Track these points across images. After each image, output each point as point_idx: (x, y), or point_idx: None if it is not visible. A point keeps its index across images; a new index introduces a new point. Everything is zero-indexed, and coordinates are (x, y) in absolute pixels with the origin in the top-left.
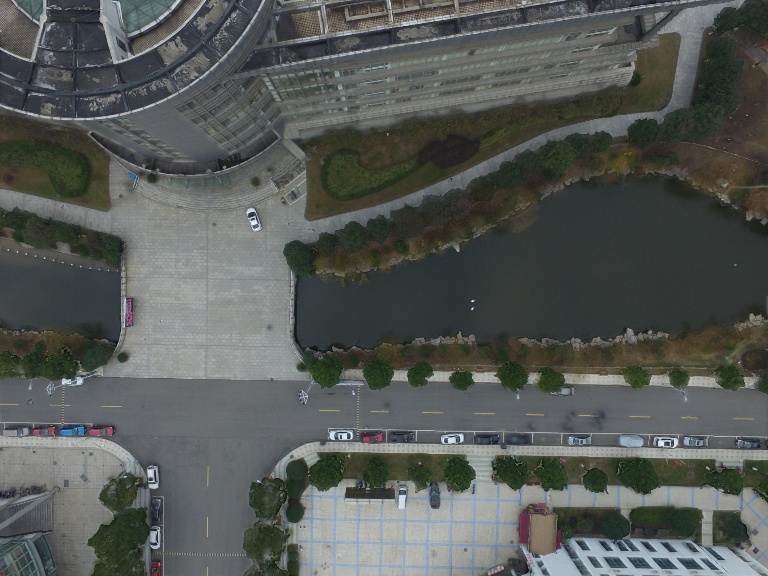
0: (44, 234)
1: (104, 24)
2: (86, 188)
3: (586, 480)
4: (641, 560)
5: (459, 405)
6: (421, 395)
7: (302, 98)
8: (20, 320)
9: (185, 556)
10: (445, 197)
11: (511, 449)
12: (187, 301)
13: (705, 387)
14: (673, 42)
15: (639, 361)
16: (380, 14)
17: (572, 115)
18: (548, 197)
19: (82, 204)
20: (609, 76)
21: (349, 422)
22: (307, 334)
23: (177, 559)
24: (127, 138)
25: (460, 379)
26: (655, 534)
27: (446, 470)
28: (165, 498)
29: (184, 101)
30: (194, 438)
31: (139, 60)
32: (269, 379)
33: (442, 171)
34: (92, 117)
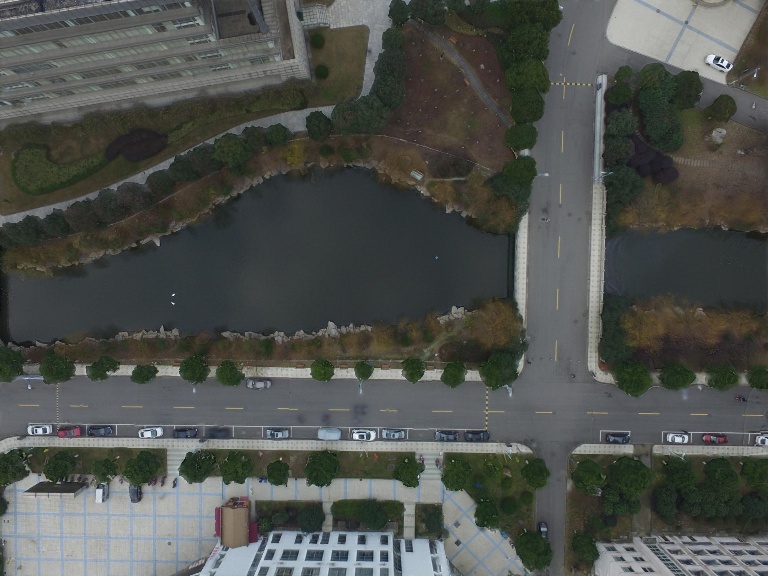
0: None
1: None
2: None
3: (267, 473)
4: (319, 552)
5: (158, 399)
6: (120, 389)
7: None
8: None
9: None
10: (116, 191)
11: (211, 443)
12: None
13: (403, 380)
14: (361, 34)
15: (338, 354)
16: None
17: (259, 108)
18: None
19: None
20: (277, 69)
21: (49, 417)
22: (20, 329)
23: None
24: None
25: (135, 373)
26: (358, 527)
27: (126, 464)
28: None
29: None
30: None
31: None
32: None
33: (134, 165)
34: None
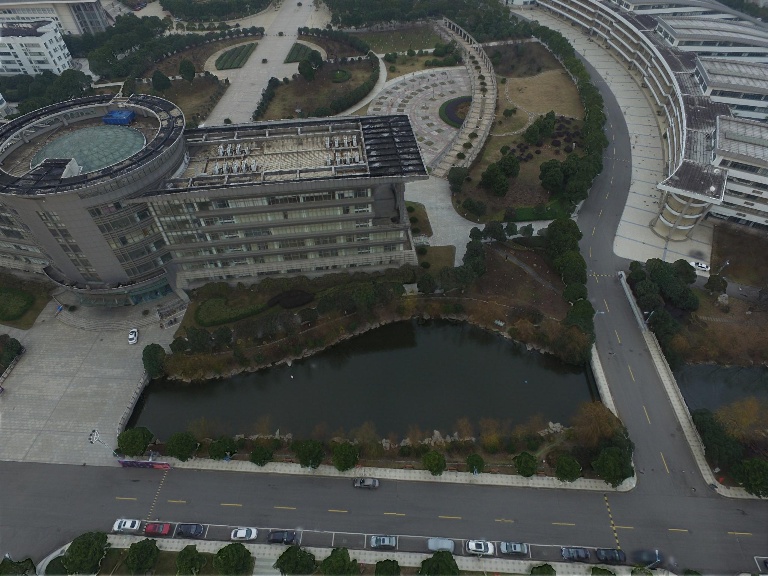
0: None
1: (67, 167)
2: (21, 315)
3: (376, 573)
4: None
5: (260, 497)
6: (224, 485)
7: (184, 244)
8: None
9: None
10: None
11: (307, 552)
12: (47, 393)
13: (515, 486)
14: (451, 249)
15: None
16: None
17: (382, 281)
18: (369, 334)
19: (11, 325)
20: (399, 255)
21: (141, 512)
22: None
23: None
24: (57, 242)
25: (256, 449)
26: None
27: None
28: None
29: (94, 206)
30: None
31: (75, 178)
32: (82, 464)
33: None
34: (33, 195)
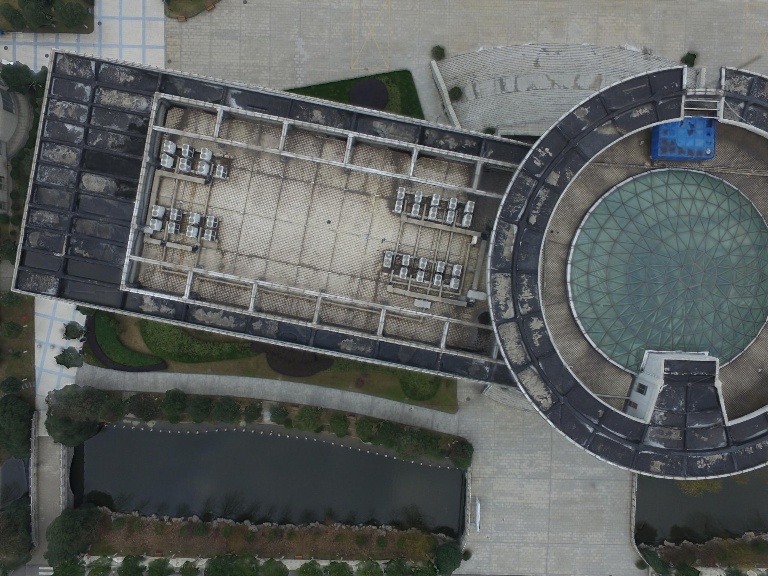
0: (418, 451)
1: (719, 389)
2: (436, 392)
3: None
4: None
5: None
6: None
7: None
8: (342, 505)
9: None
10: None
11: None
12: (530, 500)
13: None
14: None
15: None
16: None
17: None
18: None
19: (430, 406)
20: None
21: None
22: None
23: None
24: None
25: None
26: None
27: None
28: None
29: None
30: None
31: (748, 421)
32: (608, 575)
33: None
34: (703, 476)
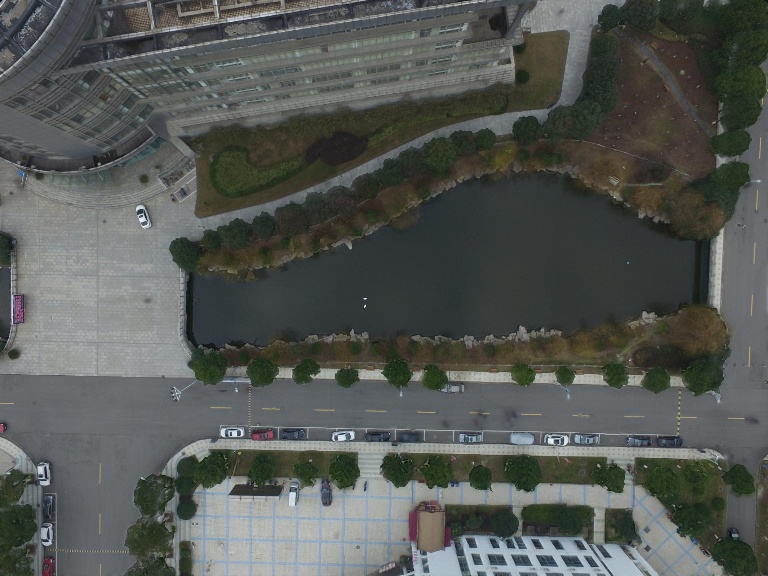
0: None
1: None
2: None
3: (471, 477)
4: (524, 557)
5: (350, 402)
6: (312, 392)
7: (166, 95)
8: None
9: (78, 553)
10: (327, 194)
11: (402, 446)
12: (78, 298)
13: (596, 385)
14: (562, 39)
15: (530, 359)
16: (212, 10)
17: (460, 112)
18: None
19: None
20: (490, 73)
21: (241, 419)
22: (203, 331)
23: (70, 556)
24: None
25: (343, 376)
26: (547, 532)
27: (330, 467)
28: (58, 495)
29: (8, 97)
30: (86, 435)
31: None
32: (160, 376)
33: (332, 168)
34: None
